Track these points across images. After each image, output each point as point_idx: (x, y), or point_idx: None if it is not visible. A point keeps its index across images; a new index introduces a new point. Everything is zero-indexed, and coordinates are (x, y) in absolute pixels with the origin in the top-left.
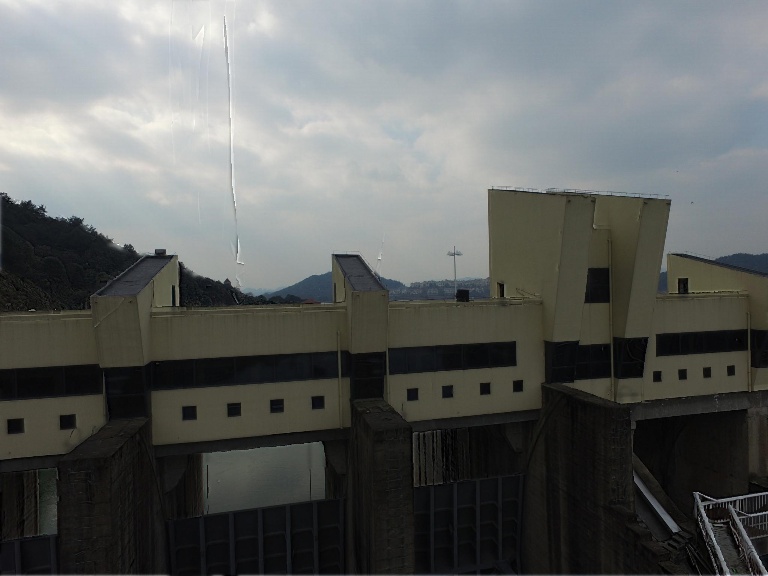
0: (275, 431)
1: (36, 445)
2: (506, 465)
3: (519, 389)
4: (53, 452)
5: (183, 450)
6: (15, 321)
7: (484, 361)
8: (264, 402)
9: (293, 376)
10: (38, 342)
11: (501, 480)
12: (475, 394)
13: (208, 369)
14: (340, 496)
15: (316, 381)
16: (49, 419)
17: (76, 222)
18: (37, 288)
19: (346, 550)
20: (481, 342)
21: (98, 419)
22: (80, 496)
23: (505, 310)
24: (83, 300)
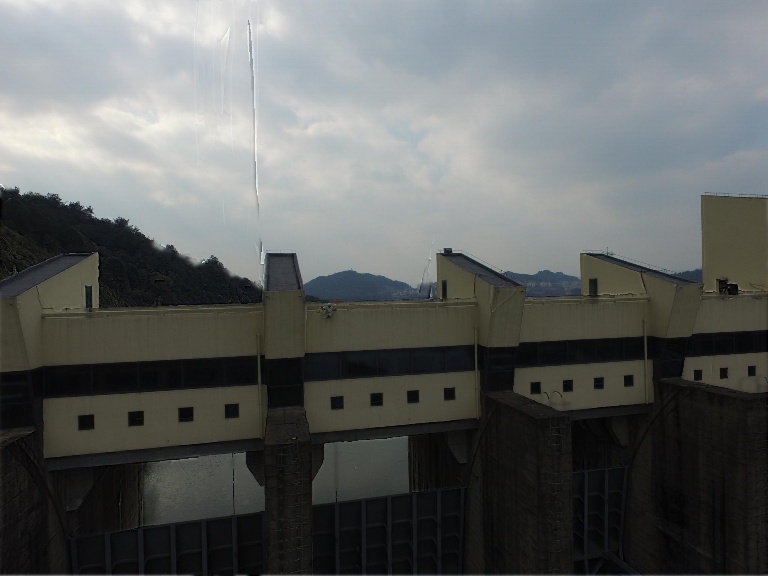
0: (597, 405)
1: (427, 413)
2: None
3: None
4: (439, 419)
5: None
6: (412, 308)
7: (750, 347)
8: (589, 380)
9: (609, 358)
10: (428, 326)
11: None
12: (744, 376)
13: (545, 351)
14: (599, 468)
15: (627, 362)
16: (436, 391)
17: (121, 223)
18: (106, 287)
19: (627, 513)
20: (749, 330)
21: (470, 392)
22: (552, 447)
23: (767, 302)
24: (156, 299)
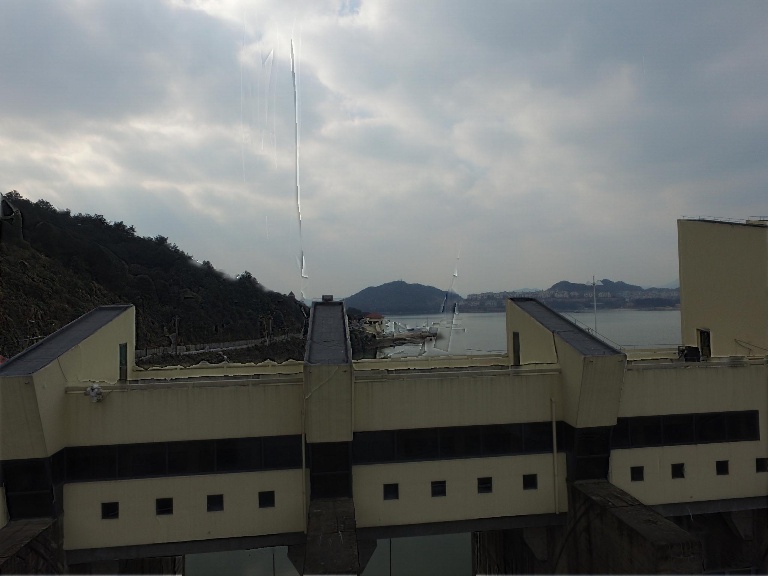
0: (483, 514)
1: (235, 524)
2: (718, 549)
3: (763, 469)
4: (251, 533)
5: (383, 533)
6: (215, 387)
7: (720, 434)
8: (470, 480)
9: (501, 450)
10: (237, 410)
11: (729, 575)
12: (710, 474)
13: (408, 440)
14: None
15: (527, 456)
16: (248, 496)
17: (161, 241)
18: None
19: None
20: (716, 411)
21: (297, 497)
22: None
23: (744, 372)
24: (174, 317)
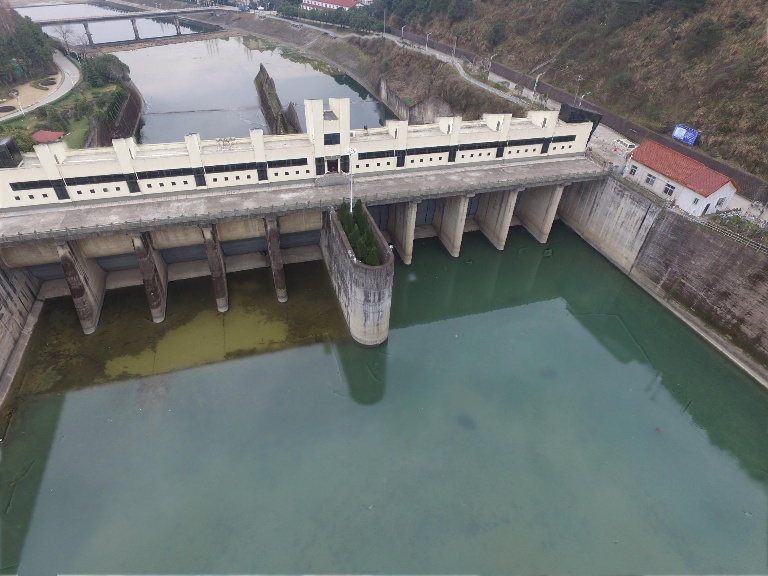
0: None
1: None
2: None
3: None
4: None
5: None
6: (463, 123)
7: None
8: None
9: None
10: None
11: None
12: None
13: None
14: None
15: None
16: None
17: None
18: None
19: None
20: None
21: None
22: None
23: None
24: None
